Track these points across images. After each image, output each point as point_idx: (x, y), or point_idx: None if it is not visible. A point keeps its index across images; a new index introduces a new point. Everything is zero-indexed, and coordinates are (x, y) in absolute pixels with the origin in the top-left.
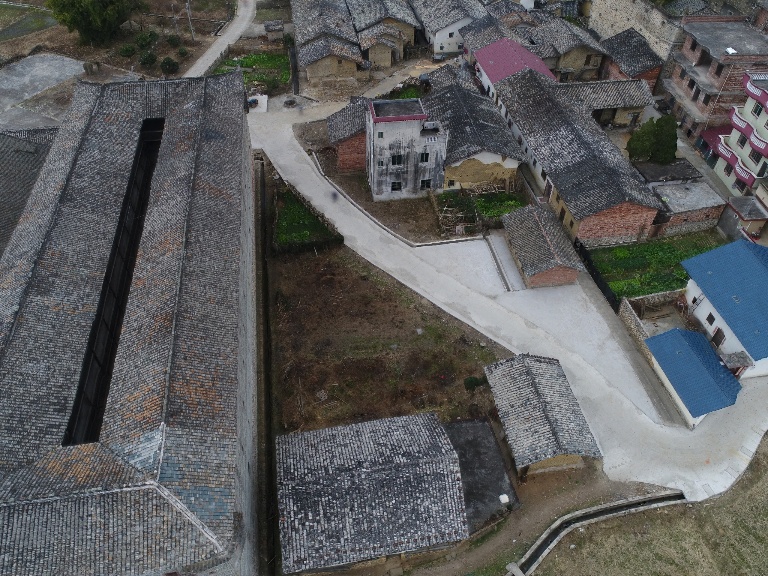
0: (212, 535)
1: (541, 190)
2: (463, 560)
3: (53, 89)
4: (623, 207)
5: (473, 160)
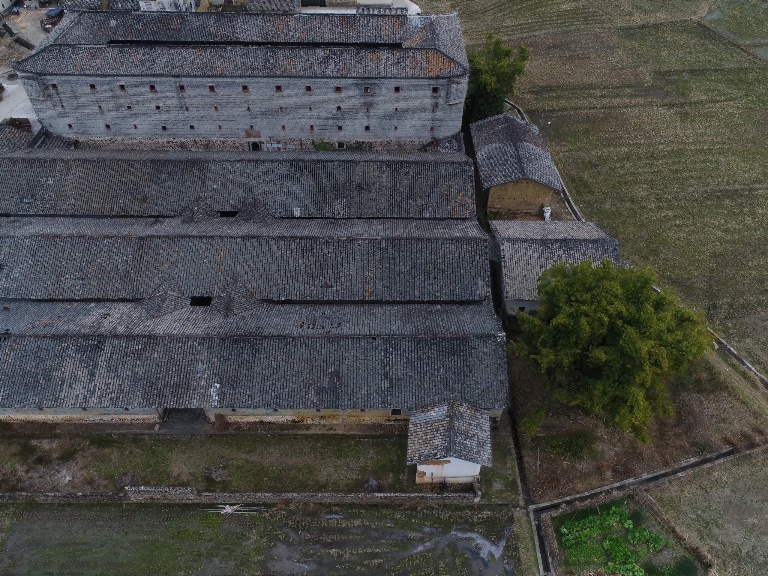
0: None
1: None
2: None
3: None
4: None
5: None
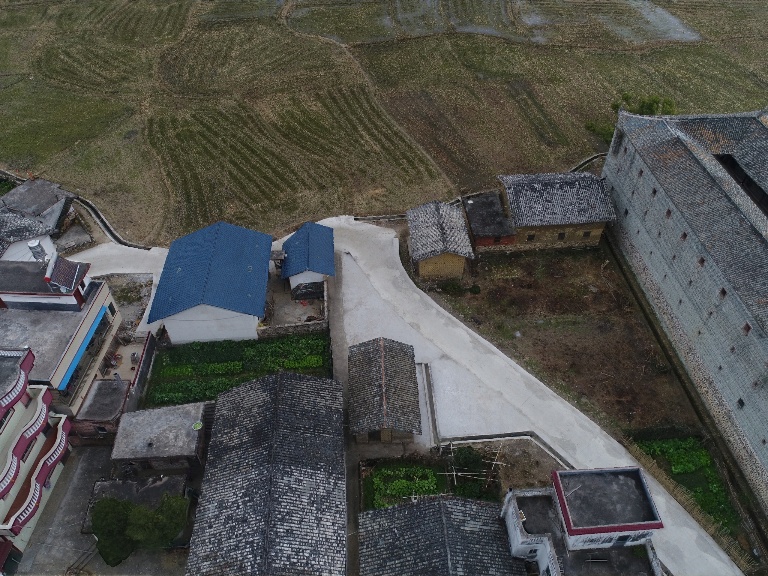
0: None
1: None
2: None
3: None
4: None
5: None
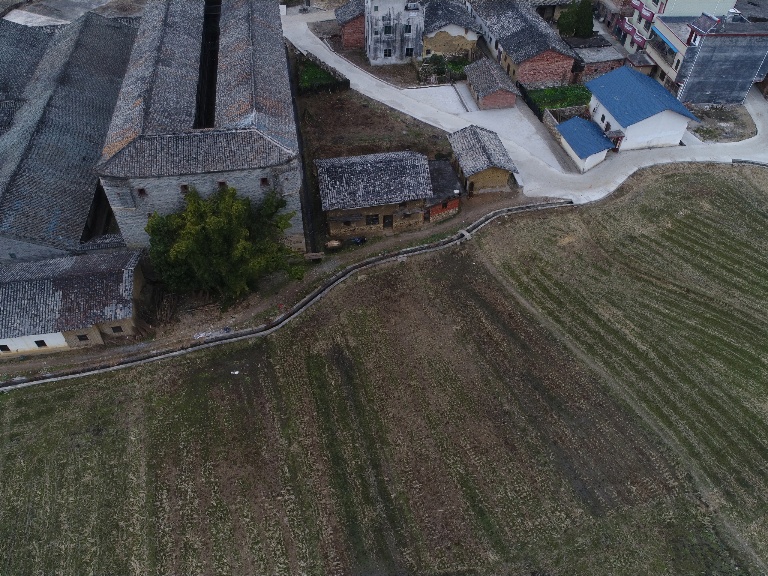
0: (289, 148)
1: (495, 59)
2: (431, 230)
3: (114, 2)
4: (549, 55)
5: (444, 32)
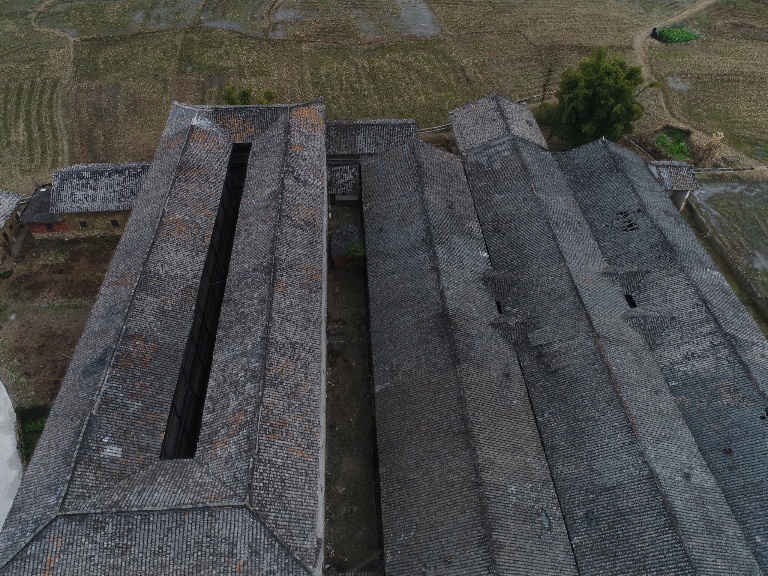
0: None
1: None
2: None
3: None
4: None
5: None
